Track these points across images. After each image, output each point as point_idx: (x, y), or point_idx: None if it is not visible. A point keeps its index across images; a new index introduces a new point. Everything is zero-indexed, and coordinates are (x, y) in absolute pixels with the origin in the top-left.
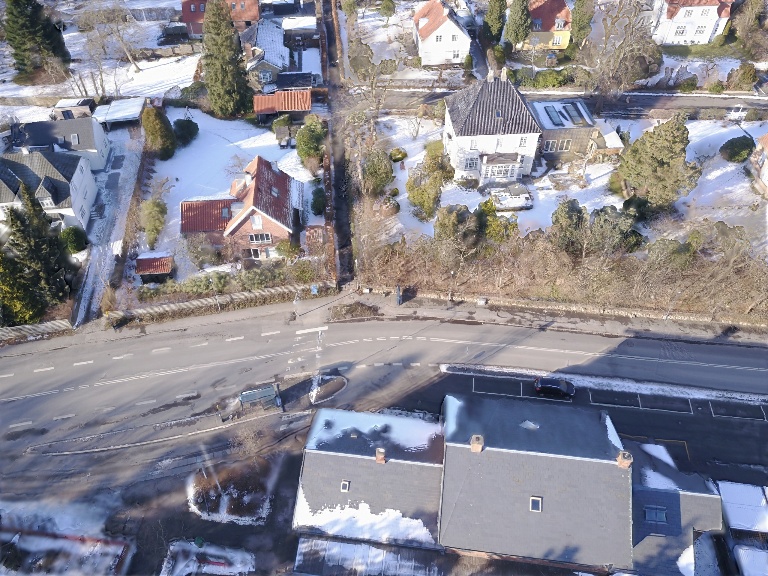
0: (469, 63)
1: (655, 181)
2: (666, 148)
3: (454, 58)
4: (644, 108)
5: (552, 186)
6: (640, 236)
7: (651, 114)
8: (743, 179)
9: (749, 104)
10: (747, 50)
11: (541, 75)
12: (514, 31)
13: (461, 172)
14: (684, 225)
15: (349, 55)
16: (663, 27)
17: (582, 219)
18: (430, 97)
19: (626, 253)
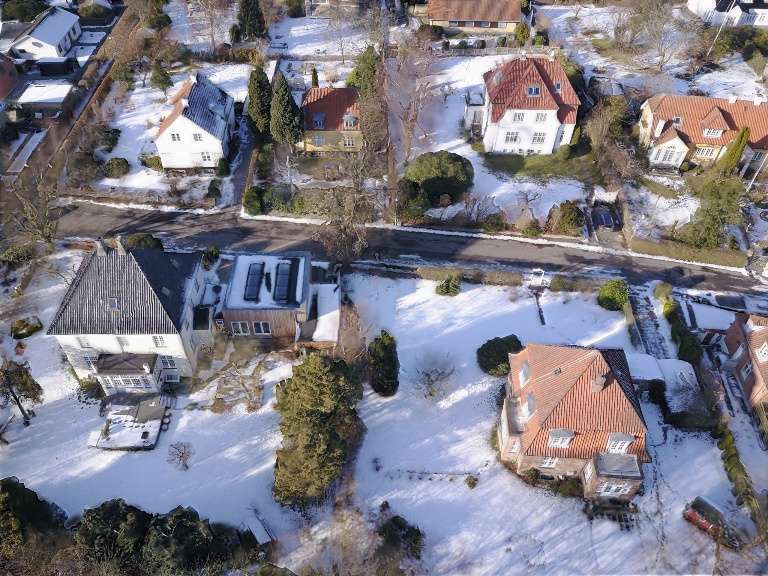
0: (222, 169)
1: (279, 460)
2: (313, 400)
3: (205, 161)
4: (422, 257)
5: (213, 401)
6: (254, 544)
7: (418, 273)
8: (489, 412)
9: (569, 258)
10: (598, 168)
11: (298, 198)
12: (279, 131)
13: (85, 371)
14: (345, 515)
15: (80, 146)
16: (489, 131)
17: (114, 543)
18: (147, 219)
19: (229, 570)
